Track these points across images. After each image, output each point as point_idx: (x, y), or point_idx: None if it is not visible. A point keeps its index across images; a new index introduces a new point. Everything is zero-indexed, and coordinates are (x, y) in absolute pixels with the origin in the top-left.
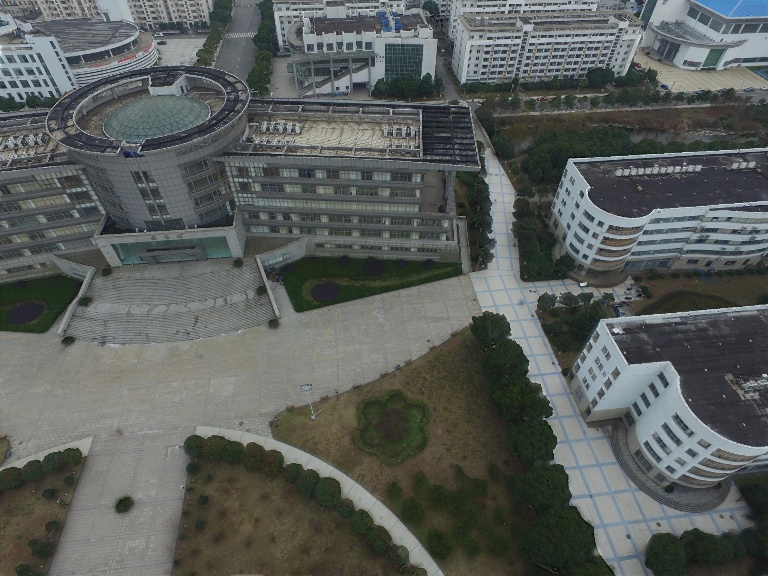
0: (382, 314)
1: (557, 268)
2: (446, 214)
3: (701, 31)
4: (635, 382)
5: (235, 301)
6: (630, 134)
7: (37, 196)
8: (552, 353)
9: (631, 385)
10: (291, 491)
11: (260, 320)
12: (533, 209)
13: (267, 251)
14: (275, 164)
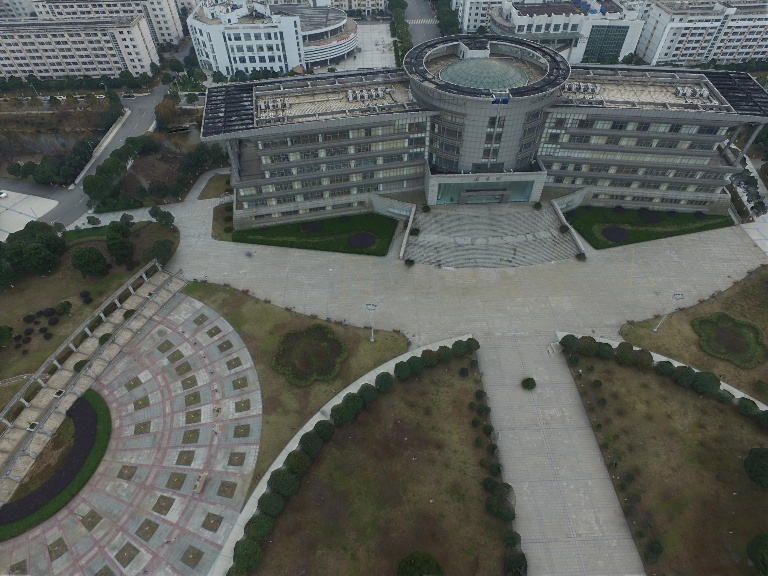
0: (675, 254)
1: None
2: (734, 167)
3: None
4: None
5: (544, 237)
6: None
7: (388, 139)
8: None
9: None
10: (666, 383)
11: (567, 254)
12: None
13: (560, 197)
14: (596, 116)
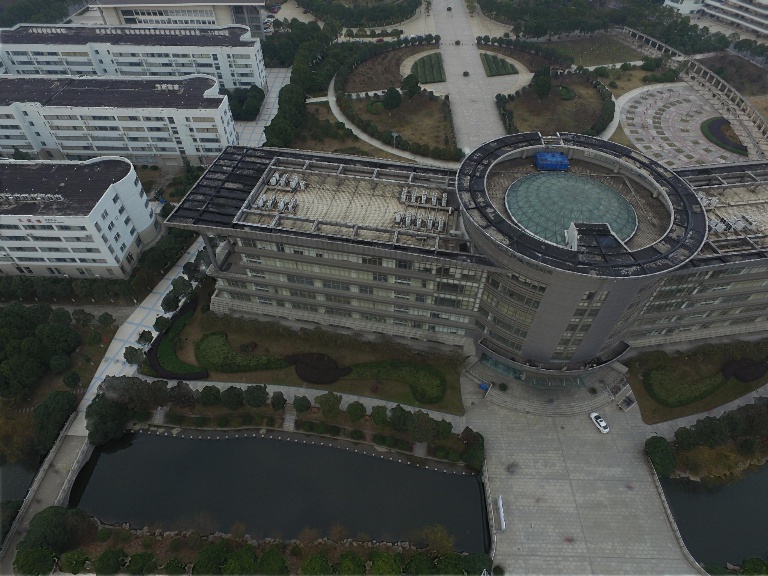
0: None
1: None
2: None
3: None
4: None
5: None
6: None
7: None
8: None
9: None
10: None
11: None
12: None
13: None
14: None
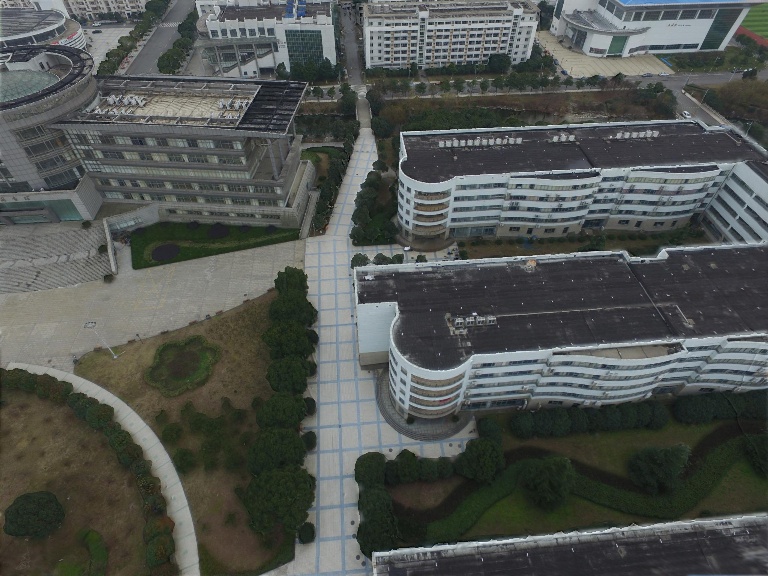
0: (211, 272)
1: (381, 233)
2: (275, 181)
3: (609, 19)
4: (378, 323)
5: (77, 258)
6: (519, 117)
7: None
8: (354, 307)
9: (377, 326)
10: (73, 416)
11: (98, 275)
12: (389, 183)
13: (115, 215)
14: (106, 132)
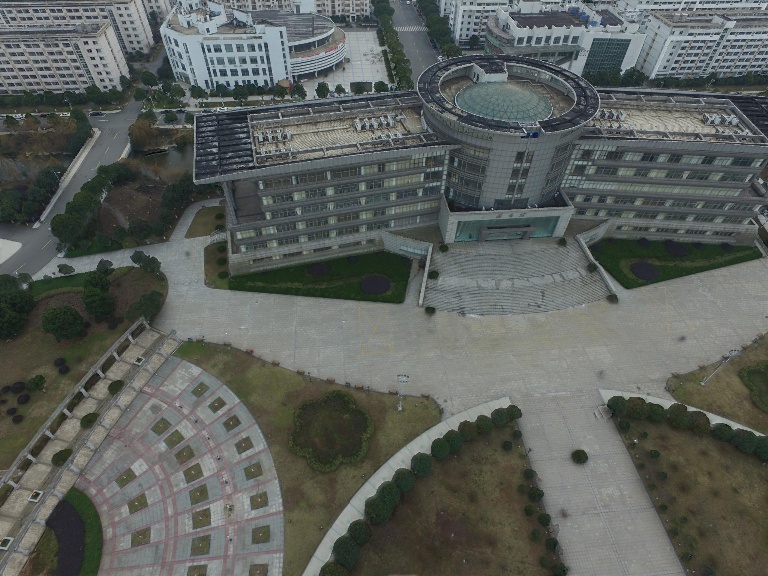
0: (708, 292)
1: None
2: (765, 199)
3: None
4: None
5: (572, 277)
6: None
7: (403, 174)
8: None
9: None
10: (724, 448)
11: (598, 295)
12: None
13: None
14: (627, 148)
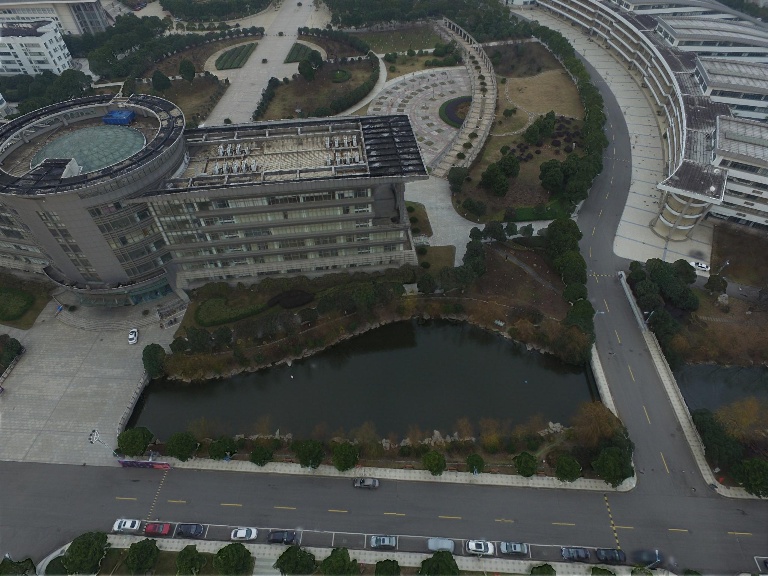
0: None
1: None
2: None
3: None
4: None
5: None
6: None
7: None
8: None
9: None
10: None
11: None
12: None
13: None
14: None
